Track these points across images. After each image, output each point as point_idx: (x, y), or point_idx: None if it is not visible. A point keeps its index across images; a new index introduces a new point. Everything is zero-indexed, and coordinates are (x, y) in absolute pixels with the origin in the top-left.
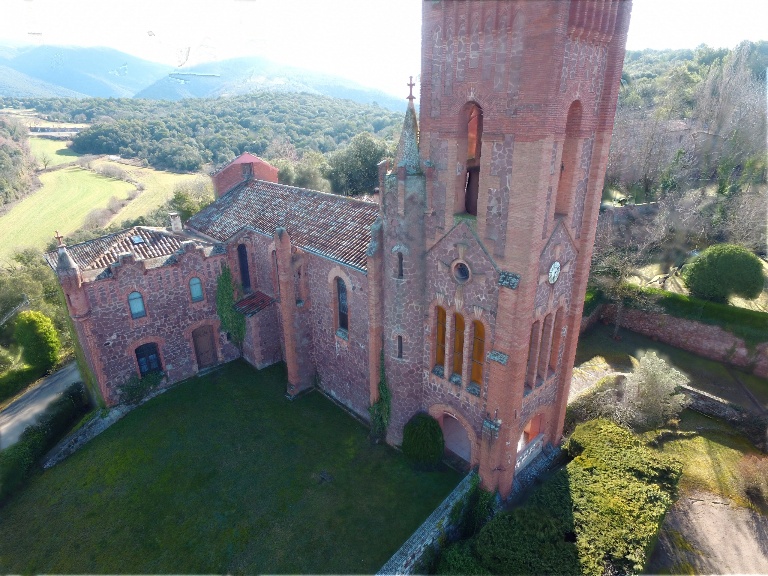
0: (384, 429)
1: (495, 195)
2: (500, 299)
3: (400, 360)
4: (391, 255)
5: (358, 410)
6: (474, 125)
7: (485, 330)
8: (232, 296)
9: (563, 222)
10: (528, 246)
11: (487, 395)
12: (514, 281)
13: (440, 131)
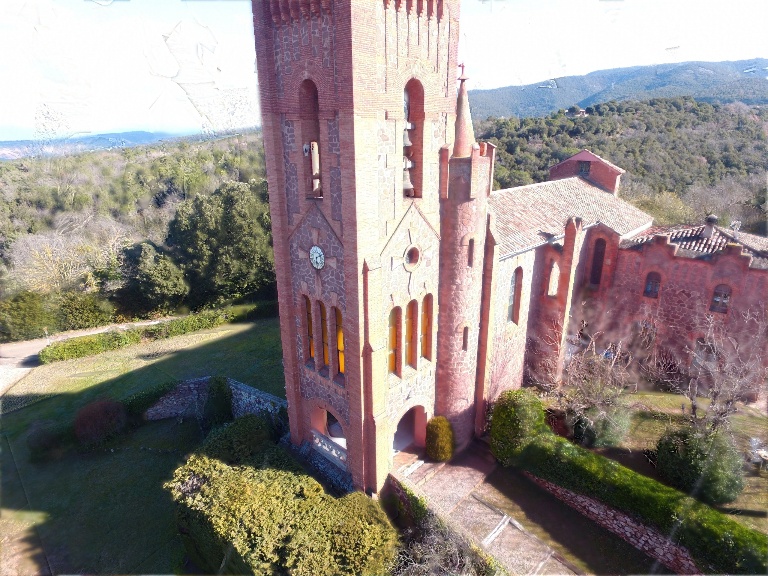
0: None
1: None
2: None
3: None
4: None
5: None
6: None
7: None
8: None
9: (317, 206)
10: None
11: None
12: None
13: None
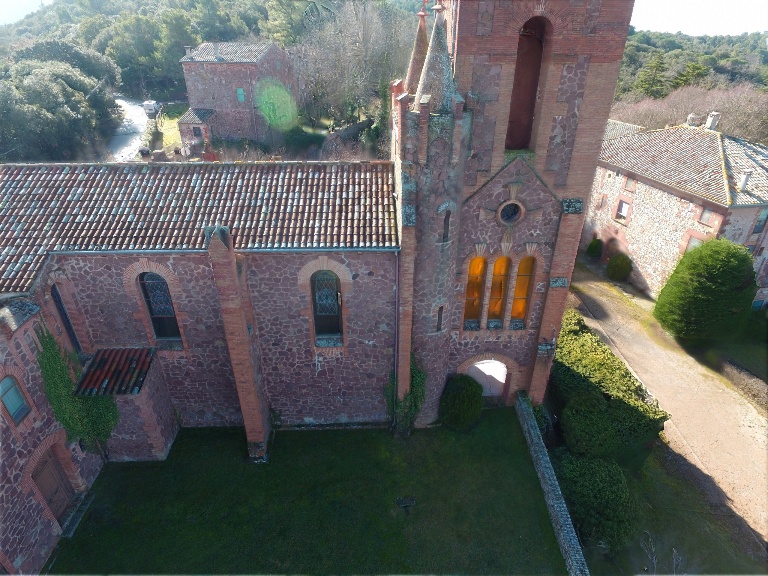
0: (414, 416)
1: (560, 123)
2: (562, 227)
3: (439, 333)
4: (437, 217)
5: (360, 418)
6: None
7: (538, 263)
8: (68, 378)
9: None
10: (594, 168)
11: (542, 322)
12: (579, 206)
13: (491, 53)
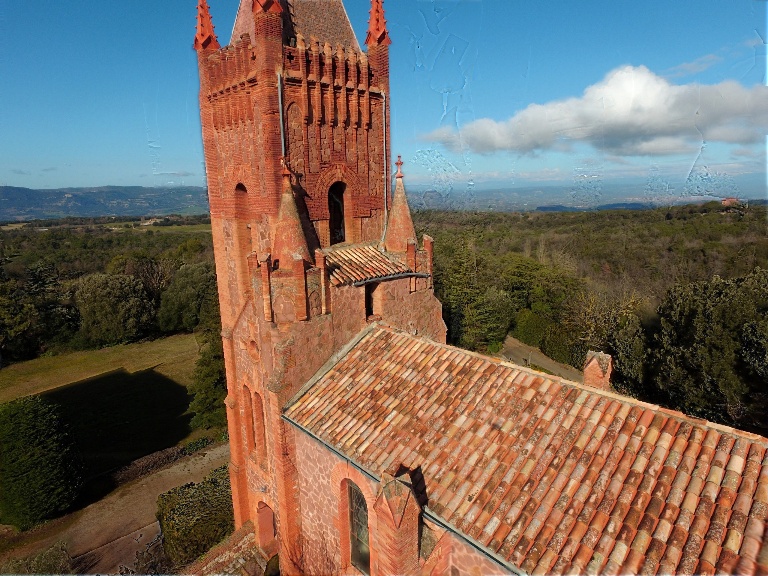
0: None
1: None
2: None
3: None
4: None
5: None
6: None
7: None
8: None
9: None
10: None
11: None
12: None
13: None
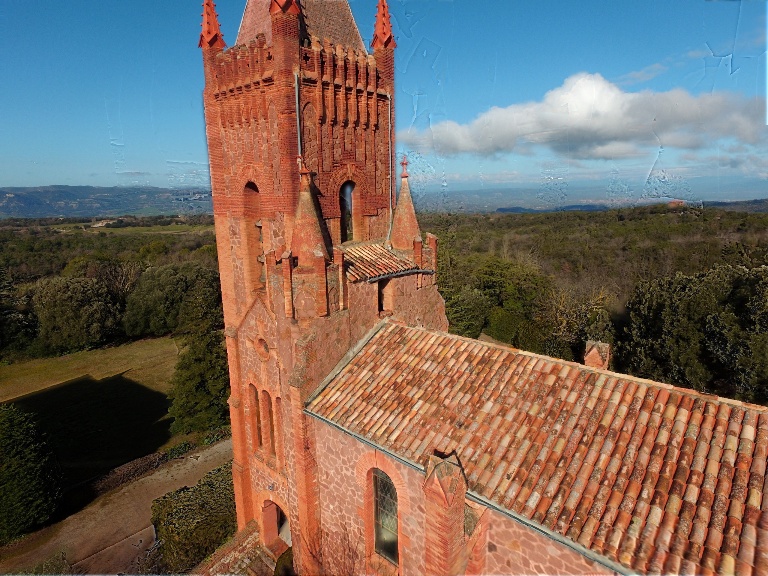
0: None
1: None
2: None
3: None
4: None
5: None
6: (334, 205)
7: None
8: None
9: None
10: None
11: None
12: None
13: None
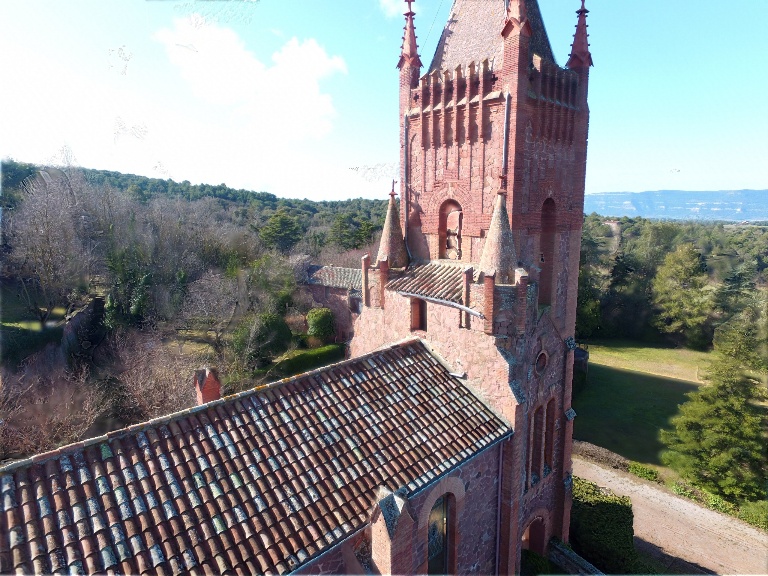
0: None
1: (560, 278)
2: None
3: None
4: (527, 385)
5: None
6: None
7: None
8: None
9: None
10: None
11: (564, 458)
12: None
13: (529, 228)
